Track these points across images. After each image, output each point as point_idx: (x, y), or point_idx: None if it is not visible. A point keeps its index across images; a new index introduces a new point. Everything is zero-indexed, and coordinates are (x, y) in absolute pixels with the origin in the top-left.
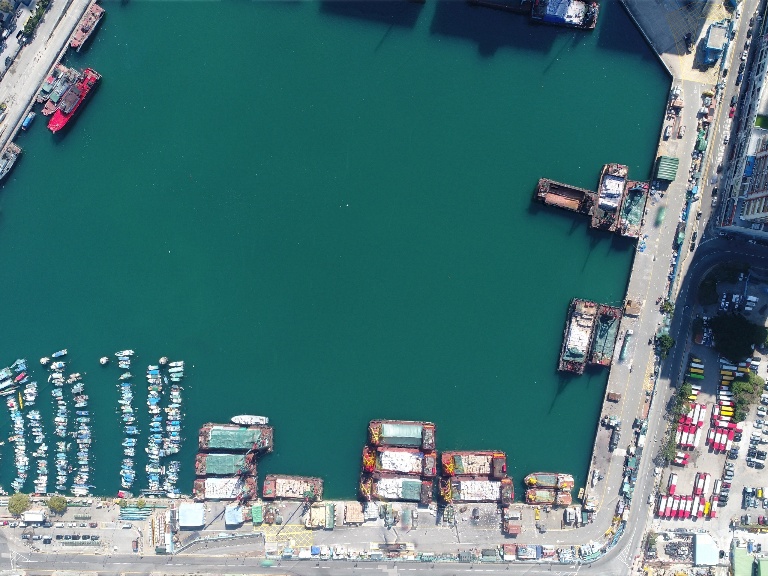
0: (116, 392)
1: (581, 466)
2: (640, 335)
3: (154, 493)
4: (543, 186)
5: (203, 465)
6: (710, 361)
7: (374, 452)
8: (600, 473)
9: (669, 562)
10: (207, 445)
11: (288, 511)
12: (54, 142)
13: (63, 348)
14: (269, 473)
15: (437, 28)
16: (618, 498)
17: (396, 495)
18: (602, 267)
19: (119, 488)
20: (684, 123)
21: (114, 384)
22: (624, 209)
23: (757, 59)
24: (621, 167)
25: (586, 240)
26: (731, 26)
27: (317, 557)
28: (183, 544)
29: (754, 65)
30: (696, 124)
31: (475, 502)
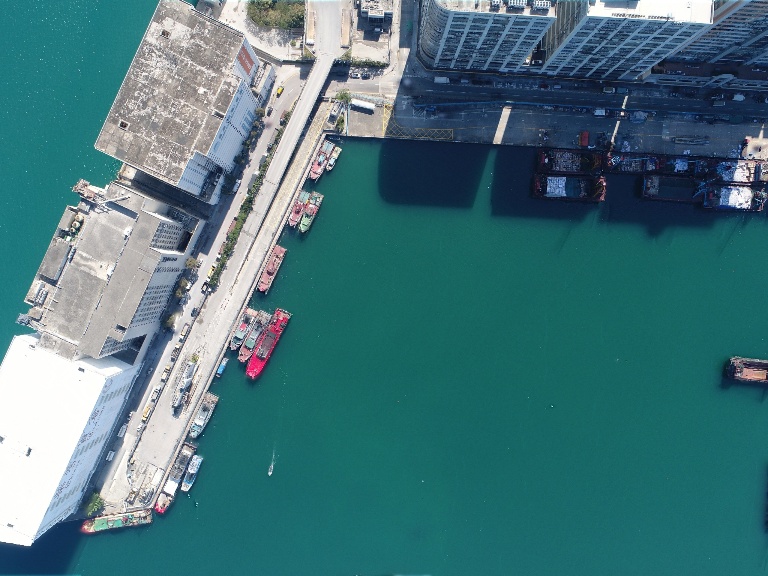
0: None
1: None
2: None
3: None
4: (739, 367)
5: None
6: None
7: None
8: None
9: None
10: None
11: None
12: (250, 384)
13: None
14: None
15: (614, 227)
16: None
17: None
18: None
19: None
20: None
21: None
22: None
23: None
24: None
25: None
26: None
27: None
28: None
29: None
30: None
31: None
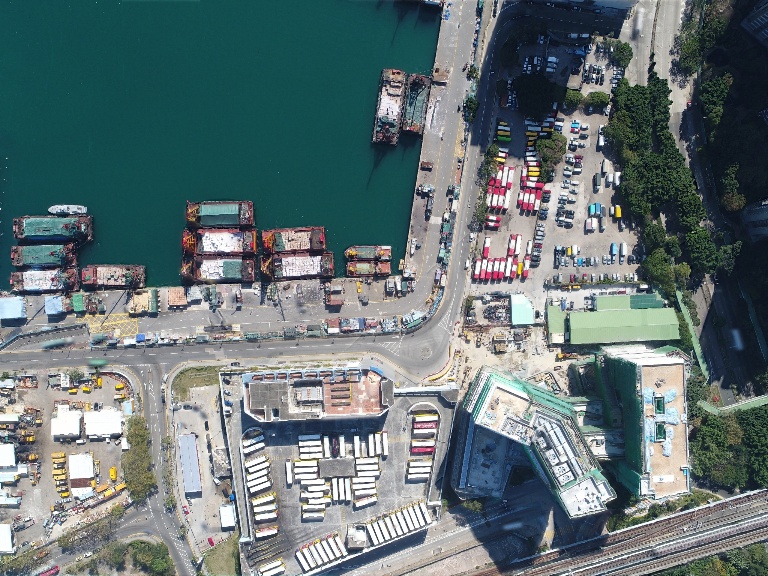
0: None
1: (400, 238)
2: (449, 103)
3: None
4: None
5: (19, 255)
6: (517, 124)
7: (194, 234)
8: (418, 242)
9: (488, 325)
10: (22, 234)
11: (111, 300)
12: None
13: None
14: (91, 264)
15: None
16: (436, 266)
17: (218, 275)
18: (410, 38)
19: None
20: None
21: None
22: None
23: None
24: None
25: (394, 13)
26: None
27: (142, 344)
28: (5, 340)
29: None
30: None
31: (298, 279)
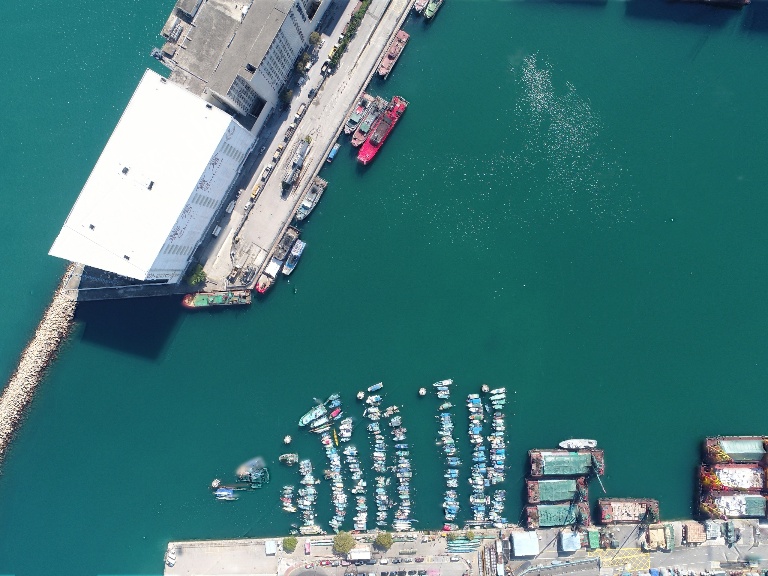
0: (435, 423)
1: None
2: None
3: (479, 524)
4: None
5: (536, 493)
6: None
7: (712, 470)
8: None
9: None
10: (540, 472)
11: (623, 534)
12: (359, 173)
13: (378, 381)
14: (599, 497)
15: (757, 34)
16: None
17: (738, 512)
18: None
19: (443, 521)
20: None
21: (432, 415)
22: None
23: None
24: None
25: None
26: None
27: None
28: (515, 574)
29: None
30: None
31: None
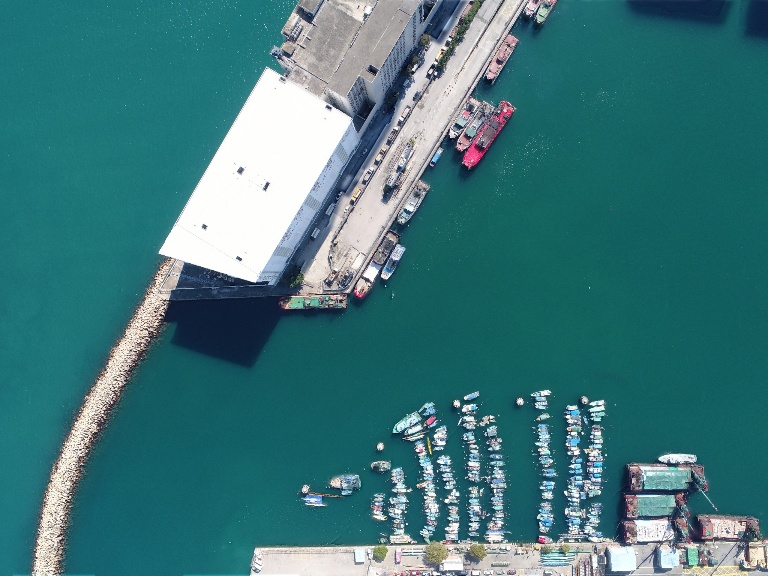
0: (531, 434)
1: None
2: None
3: (574, 537)
4: None
5: (635, 507)
6: None
7: None
8: None
9: None
10: (640, 487)
11: (721, 552)
12: (462, 178)
13: (475, 390)
14: (697, 513)
15: None
16: None
17: None
18: None
19: (537, 533)
20: None
21: (529, 426)
22: None
23: None
24: None
25: None
26: None
27: None
28: None
29: None
30: None
31: None
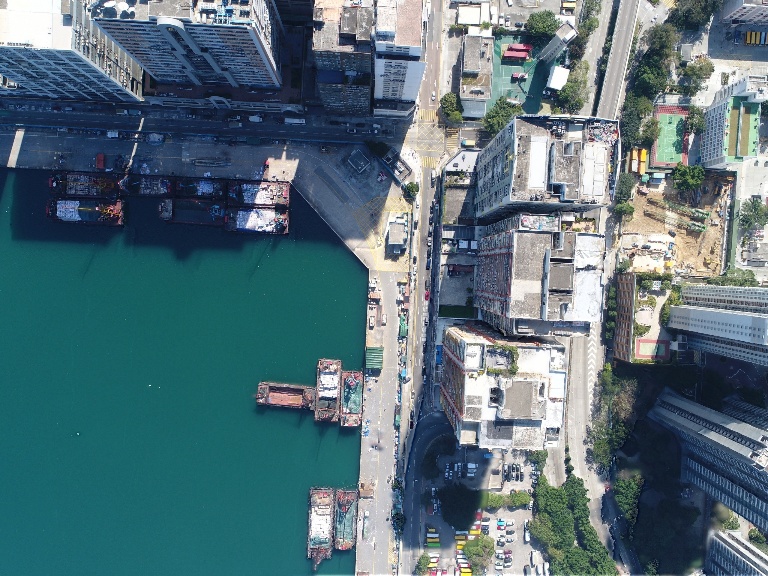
0: None
1: None
2: (378, 514)
3: None
4: (260, 393)
5: None
6: (445, 528)
7: None
8: None
9: None
10: None
11: None
12: None
13: None
14: None
15: (139, 250)
16: None
17: None
18: (334, 454)
19: None
20: (385, 311)
21: None
22: (343, 399)
23: (438, 247)
24: (331, 364)
25: (315, 430)
26: (412, 217)
27: None
28: None
29: (437, 253)
30: (397, 310)
31: None
